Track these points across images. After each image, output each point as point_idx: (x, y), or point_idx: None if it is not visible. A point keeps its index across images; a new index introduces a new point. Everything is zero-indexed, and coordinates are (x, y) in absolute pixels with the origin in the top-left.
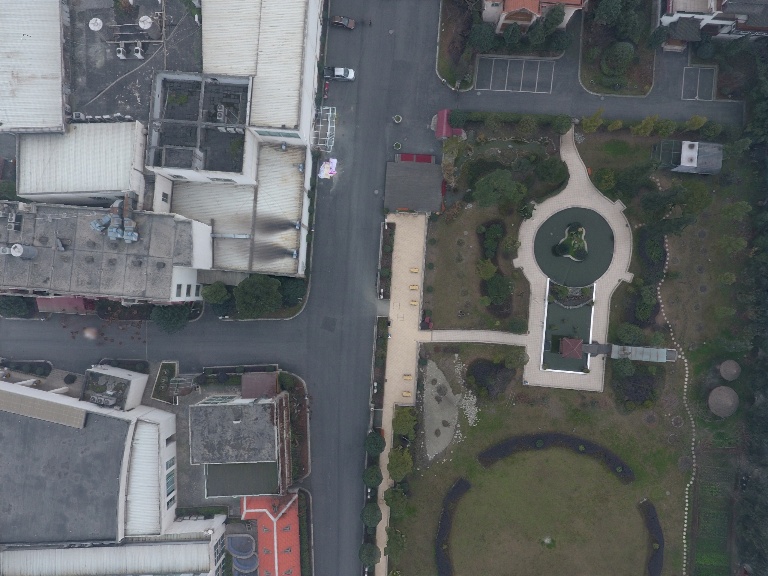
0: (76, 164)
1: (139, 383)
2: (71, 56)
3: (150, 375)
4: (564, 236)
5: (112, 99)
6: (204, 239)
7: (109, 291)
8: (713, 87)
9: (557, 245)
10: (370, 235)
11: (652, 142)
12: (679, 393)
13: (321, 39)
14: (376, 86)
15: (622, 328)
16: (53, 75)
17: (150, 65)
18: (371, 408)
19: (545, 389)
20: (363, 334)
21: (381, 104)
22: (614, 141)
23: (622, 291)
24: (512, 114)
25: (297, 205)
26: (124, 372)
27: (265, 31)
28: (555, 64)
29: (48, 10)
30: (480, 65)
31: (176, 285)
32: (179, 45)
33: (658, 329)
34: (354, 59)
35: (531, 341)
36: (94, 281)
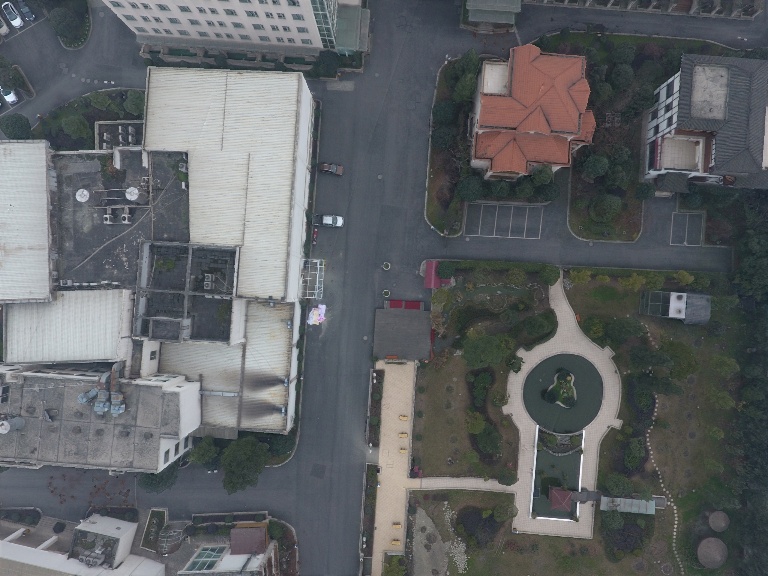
0: (63, 332)
1: (128, 536)
2: (58, 221)
3: (139, 523)
4: (553, 382)
5: (99, 264)
6: (192, 401)
7: (96, 461)
8: (701, 232)
9: (546, 392)
10: (359, 381)
11: (641, 288)
12: (668, 540)
13: (310, 186)
14: (365, 232)
15: (611, 480)
16: (40, 246)
17: (137, 229)
18: (360, 559)
19: (534, 536)
20: (352, 481)
21: (370, 250)
22: (603, 287)
23: (611, 437)
24: (501, 263)
25: (285, 361)
26: (113, 524)
27: (252, 201)
28: (544, 210)
29: (35, 181)
30: (469, 211)
31: (164, 453)
32: (166, 209)
33: (647, 478)
34: (343, 204)
35: (520, 488)
36: (81, 451)
